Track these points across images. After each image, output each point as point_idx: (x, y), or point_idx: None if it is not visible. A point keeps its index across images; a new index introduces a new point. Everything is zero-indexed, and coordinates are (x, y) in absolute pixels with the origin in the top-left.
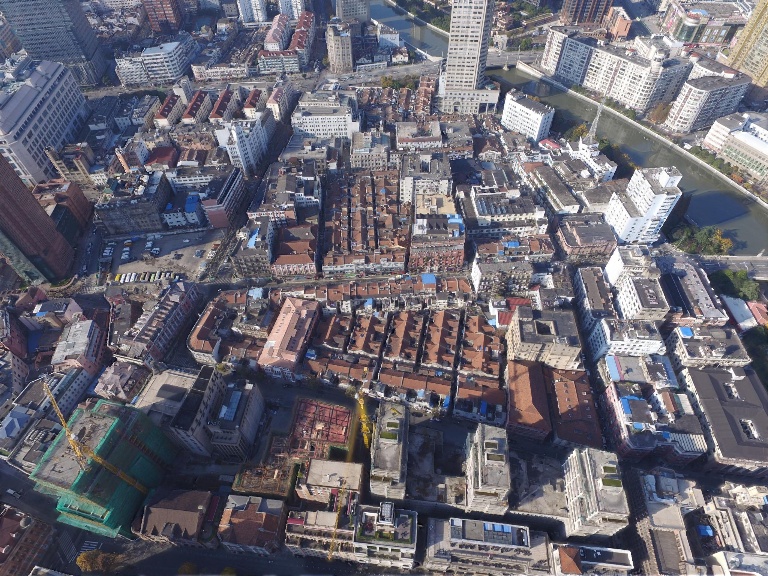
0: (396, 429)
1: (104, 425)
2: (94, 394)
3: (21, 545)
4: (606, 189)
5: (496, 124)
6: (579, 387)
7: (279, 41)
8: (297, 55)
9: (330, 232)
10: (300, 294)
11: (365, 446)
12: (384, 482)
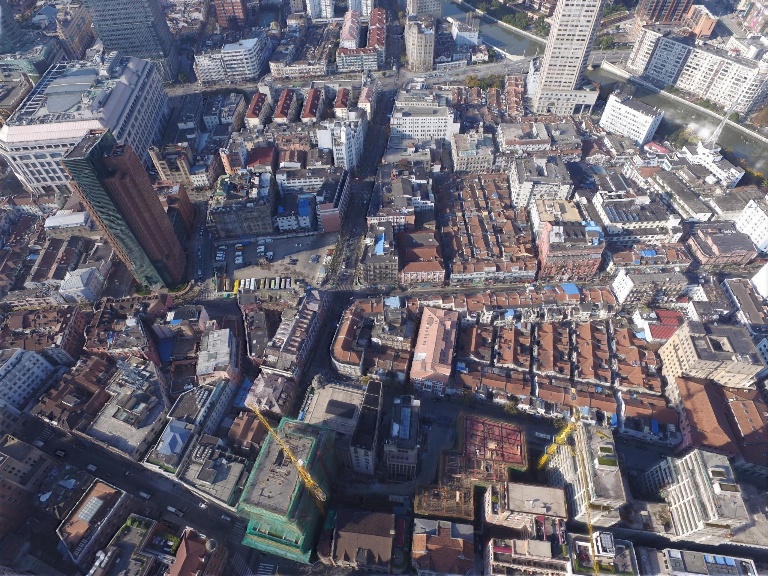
0: (611, 455)
1: (303, 446)
2: (242, 407)
3: (208, 569)
4: (736, 196)
5: (596, 126)
6: (759, 407)
7: (356, 38)
8: (377, 53)
9: (450, 238)
10: (437, 303)
11: (537, 466)
12: (603, 511)
